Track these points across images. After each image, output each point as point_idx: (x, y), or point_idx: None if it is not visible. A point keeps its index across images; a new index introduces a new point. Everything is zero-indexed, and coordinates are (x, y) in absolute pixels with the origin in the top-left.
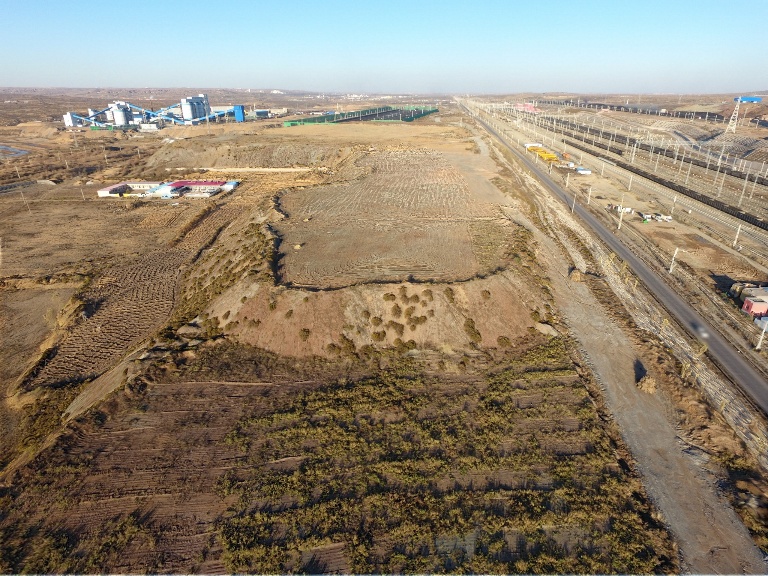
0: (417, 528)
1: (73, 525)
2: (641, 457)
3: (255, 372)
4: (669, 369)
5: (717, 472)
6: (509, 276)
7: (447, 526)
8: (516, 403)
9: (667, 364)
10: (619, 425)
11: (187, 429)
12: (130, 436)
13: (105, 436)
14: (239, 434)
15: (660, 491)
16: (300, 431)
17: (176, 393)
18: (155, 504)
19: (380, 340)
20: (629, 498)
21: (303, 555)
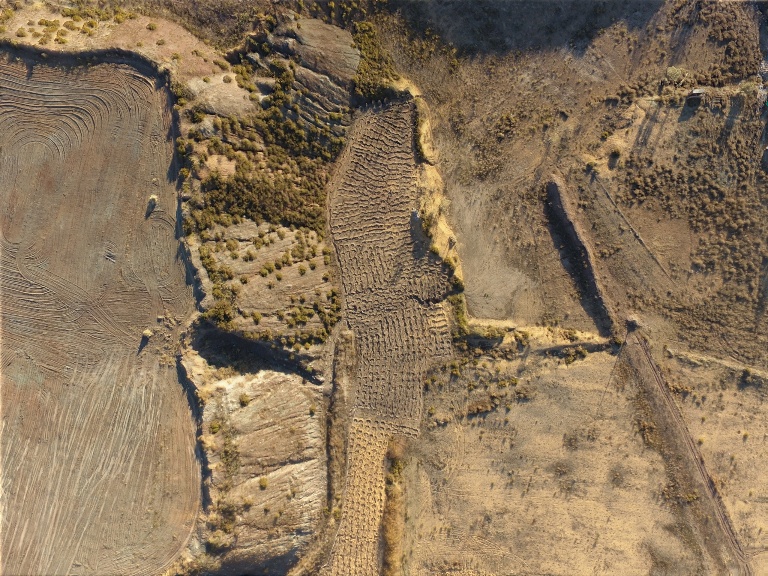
0: None
1: None
2: None
3: (197, 6)
4: None
5: None
6: None
7: None
8: None
9: None
10: None
11: None
12: None
13: None
14: None
15: None
16: None
17: None
18: None
19: None
20: None
21: None
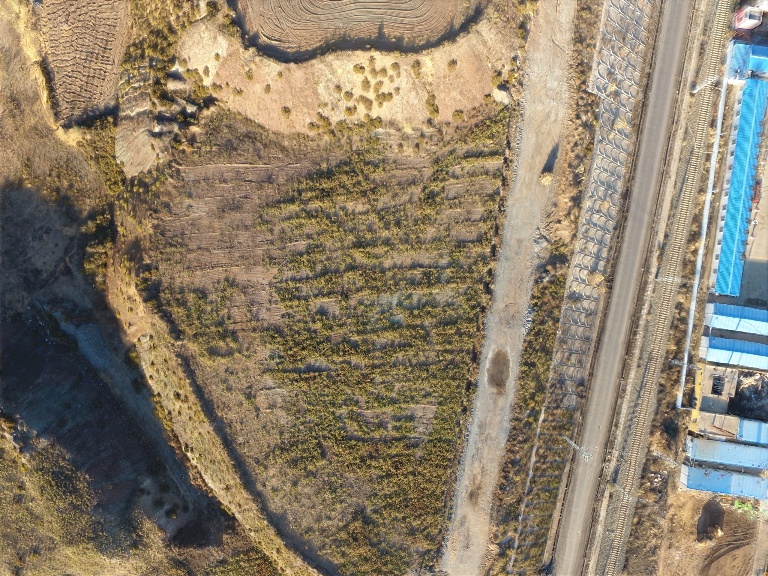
0: (370, 292)
1: (198, 286)
2: (505, 246)
3: (255, 152)
4: (573, 161)
5: (543, 256)
6: (484, 30)
7: (385, 290)
8: (447, 193)
9: (576, 153)
10: (507, 217)
11: (228, 215)
12: (194, 222)
13: (178, 221)
14: (263, 221)
15: (502, 271)
16: (301, 221)
17: (205, 178)
18: (234, 273)
19: (352, 115)
20: (484, 274)
21: (316, 304)
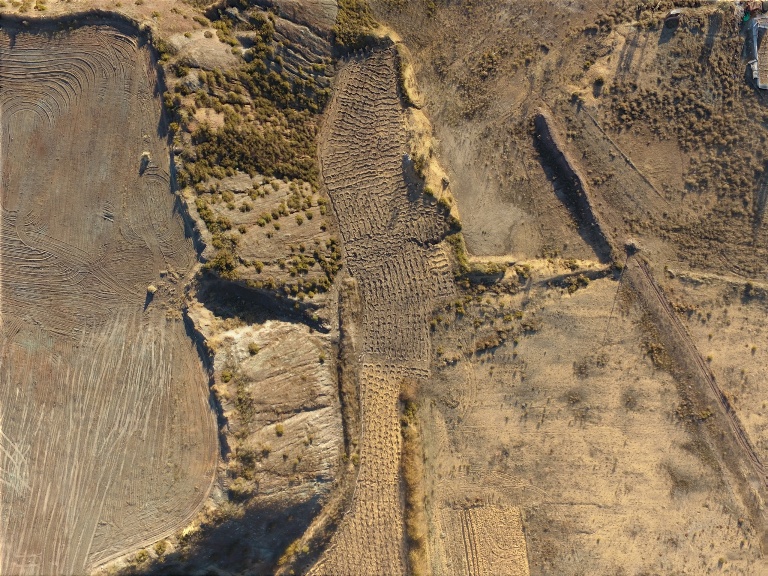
0: None
1: None
2: None
3: None
4: None
5: None
6: None
7: None
8: None
9: None
10: None
11: None
12: None
13: None
14: None
15: None
16: None
17: None
18: None
19: None
20: None
21: None
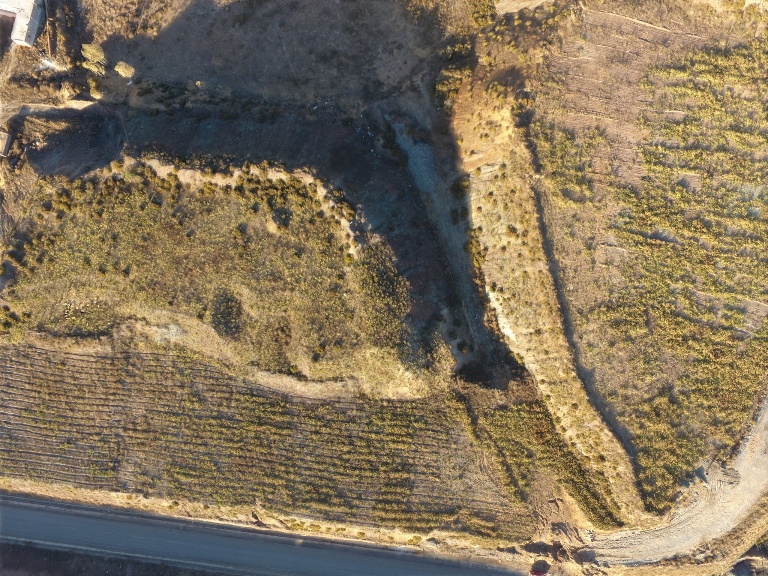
0: (736, 177)
1: (569, 127)
2: None
3: (659, 13)
4: None
5: None
6: None
7: (751, 180)
8: None
9: None
10: None
11: (615, 67)
12: (581, 64)
13: (566, 60)
14: (648, 82)
15: None
16: (687, 91)
17: (603, 24)
18: (606, 124)
19: None
20: None
21: (679, 175)
